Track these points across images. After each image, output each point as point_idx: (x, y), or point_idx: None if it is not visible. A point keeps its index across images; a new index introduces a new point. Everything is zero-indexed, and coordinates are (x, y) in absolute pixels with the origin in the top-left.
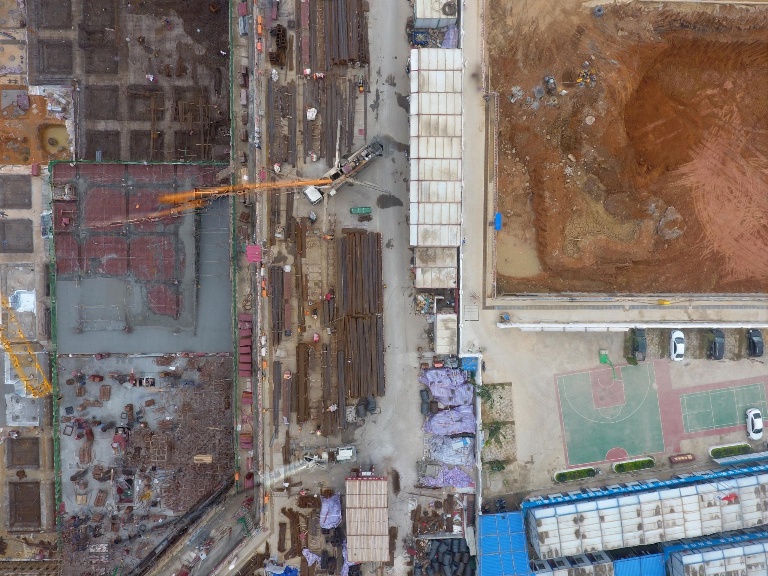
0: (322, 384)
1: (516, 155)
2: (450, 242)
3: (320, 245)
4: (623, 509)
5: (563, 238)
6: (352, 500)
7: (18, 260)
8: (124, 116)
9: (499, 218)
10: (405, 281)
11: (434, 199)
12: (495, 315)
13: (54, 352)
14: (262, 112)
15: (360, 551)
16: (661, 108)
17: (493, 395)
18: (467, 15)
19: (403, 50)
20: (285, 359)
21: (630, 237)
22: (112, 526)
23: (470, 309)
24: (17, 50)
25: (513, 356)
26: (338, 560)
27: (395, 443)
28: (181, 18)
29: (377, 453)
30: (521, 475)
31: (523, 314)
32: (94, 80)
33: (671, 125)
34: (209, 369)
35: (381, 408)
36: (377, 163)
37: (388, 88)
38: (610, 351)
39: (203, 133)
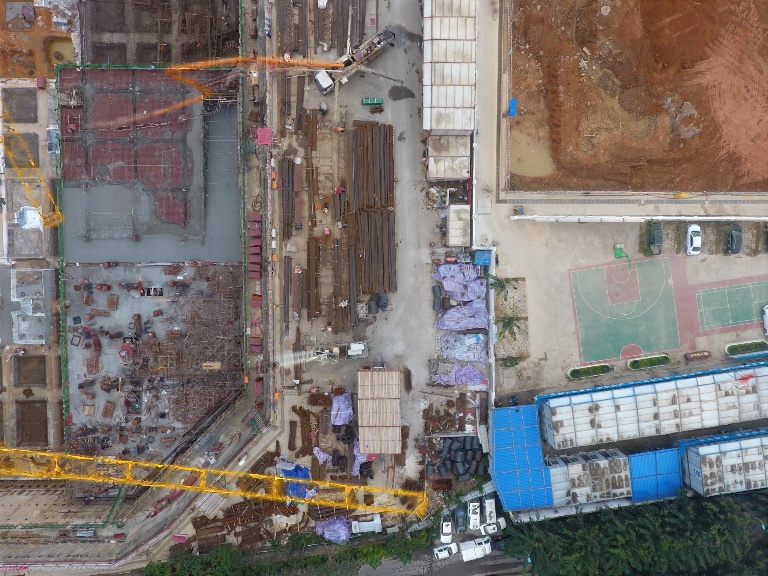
0: (333, 279)
1: (529, 51)
2: (464, 126)
3: (331, 138)
4: (639, 398)
5: (577, 135)
6: (364, 391)
7: (24, 175)
8: (130, 28)
9: (513, 104)
10: (417, 175)
11: (448, 81)
12: (508, 209)
13: (61, 261)
14: None
15: (372, 443)
16: (677, 1)
17: None
18: None
19: None
20: (295, 254)
21: (645, 134)
22: (120, 437)
23: (483, 203)
24: None
25: (527, 250)
26: (349, 459)
27: (407, 341)
28: None
29: (389, 351)
30: (535, 372)
31: (537, 208)
32: None
33: (687, 19)
34: (217, 279)
35: (393, 305)
36: (389, 53)
37: None
38: (625, 246)
39: (210, 45)
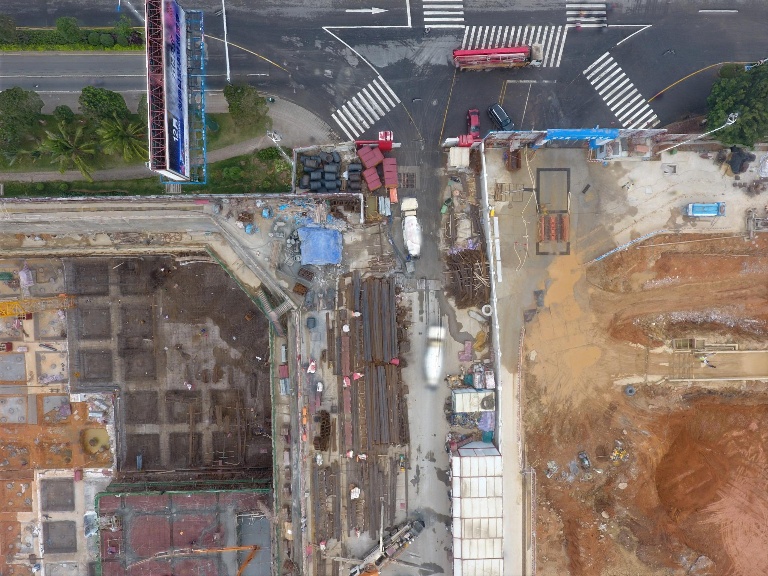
0: None
1: (550, 505)
2: None
3: None
4: None
5: None
6: None
7: (62, 559)
8: (163, 420)
9: None
10: None
11: None
12: None
13: None
14: (307, 494)
15: None
16: (690, 461)
17: None
18: (503, 397)
19: (442, 428)
20: None
21: None
22: None
23: None
24: (58, 358)
25: None
26: None
27: None
28: (217, 325)
29: None
30: None
31: None
32: (133, 386)
33: (700, 475)
34: None
35: None
36: None
37: (428, 464)
38: None
39: (240, 435)
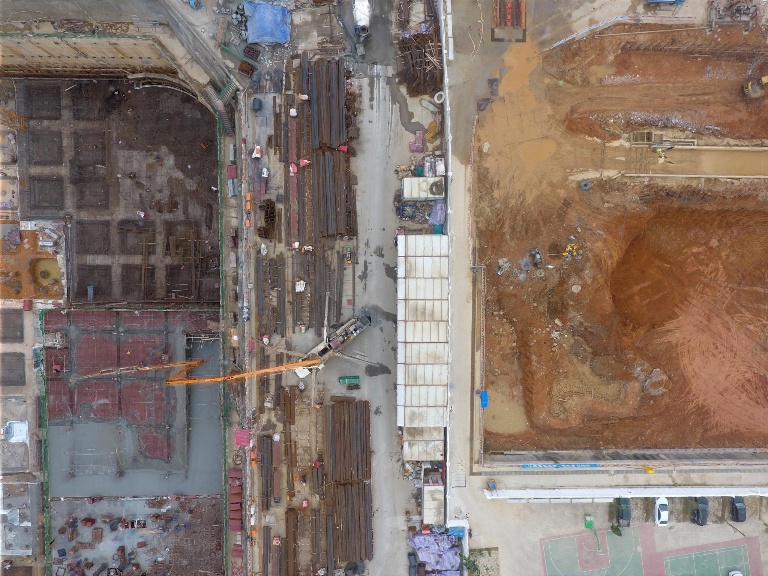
0: (311, 549)
1: (503, 316)
2: (437, 423)
3: (309, 412)
4: None
5: (550, 399)
6: None
7: (10, 393)
8: (115, 250)
9: (485, 396)
10: (393, 447)
11: (421, 382)
12: (482, 481)
13: (46, 495)
14: (251, 285)
15: None
16: (647, 271)
17: (480, 559)
18: (454, 189)
19: (391, 222)
20: (274, 524)
21: (616, 397)
22: None
23: (457, 475)
24: (8, 185)
25: (500, 521)
26: None
27: None
28: (172, 153)
29: None
30: None
31: (510, 480)
32: (85, 215)
33: (657, 287)
34: (200, 511)
35: (369, 570)
36: (365, 332)
37: (376, 259)
38: (595, 516)
39: (194, 268)
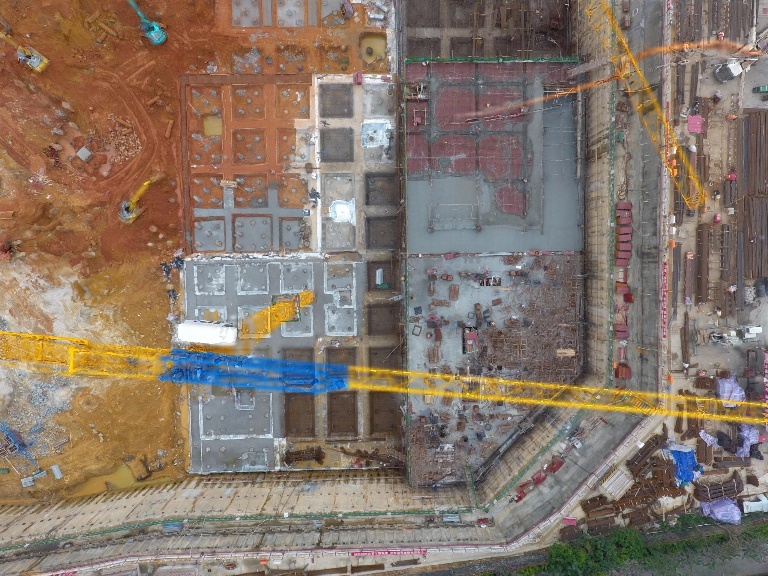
0: (724, 264)
1: None
2: None
3: (721, 126)
4: None
5: None
6: None
7: (339, 169)
8: (444, 23)
9: None
10: None
11: None
12: None
13: (403, 252)
14: None
15: None
16: None
17: None
18: None
19: None
20: (685, 240)
21: None
22: (459, 425)
23: None
24: None
25: None
26: None
27: None
28: None
29: None
30: None
31: None
32: None
33: None
34: (555, 268)
35: None
36: None
37: None
38: None
39: (524, 39)
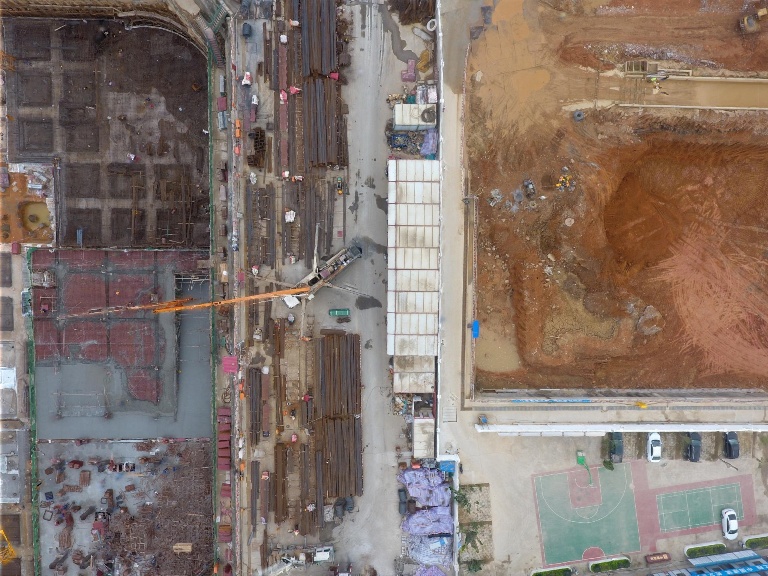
0: (300, 484)
1: (496, 252)
2: (427, 352)
3: (298, 346)
4: None
5: (542, 336)
6: None
7: None
8: (105, 194)
9: (477, 326)
10: (384, 381)
11: (411, 310)
12: (473, 416)
13: (33, 437)
14: (240, 215)
15: None
16: (641, 207)
17: (471, 496)
18: (447, 119)
19: (382, 152)
20: (263, 459)
21: (609, 335)
22: None
23: (448, 410)
24: None
25: (491, 457)
26: None
27: (373, 541)
28: (163, 96)
29: (355, 551)
30: (498, 574)
31: (501, 415)
32: (75, 158)
33: (651, 223)
34: (189, 454)
35: (359, 507)
36: (356, 265)
37: (367, 190)
38: (587, 452)
39: (185, 212)
